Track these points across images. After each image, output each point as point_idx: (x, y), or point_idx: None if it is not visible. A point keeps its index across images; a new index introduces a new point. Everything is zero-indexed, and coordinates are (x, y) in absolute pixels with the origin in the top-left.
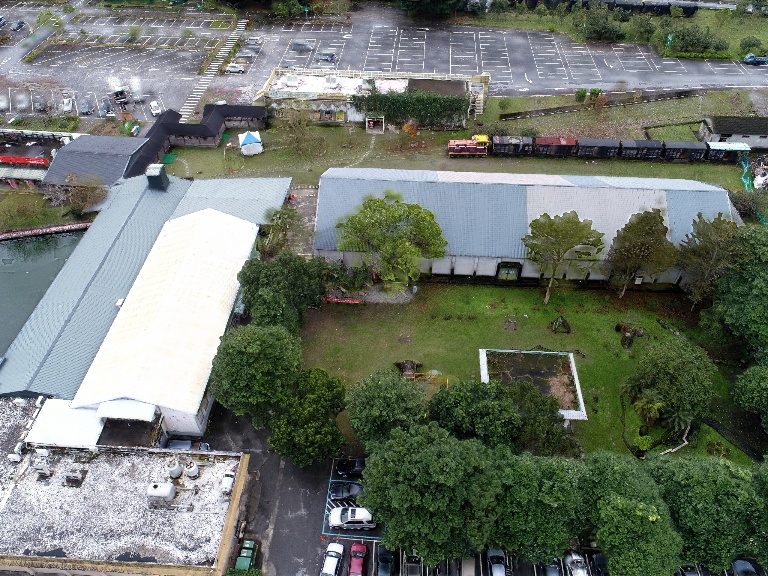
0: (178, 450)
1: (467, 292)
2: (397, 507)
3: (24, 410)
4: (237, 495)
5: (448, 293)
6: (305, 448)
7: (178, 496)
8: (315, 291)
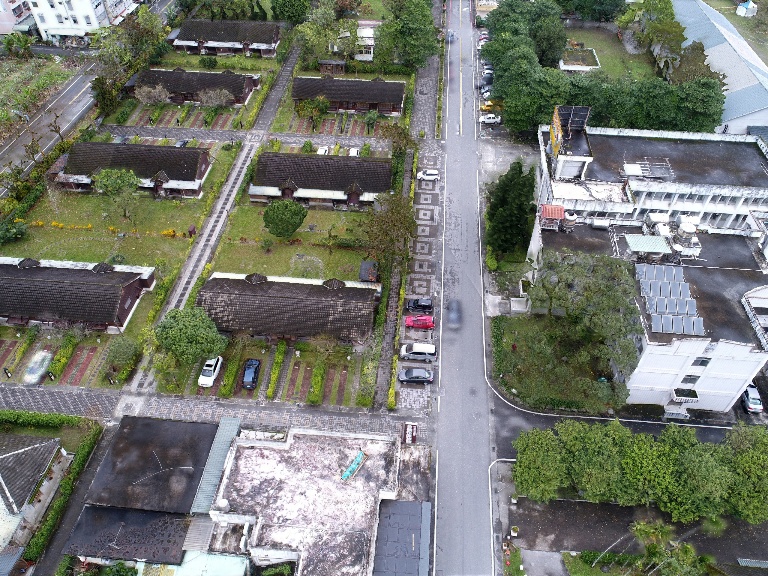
0: None
1: (647, 68)
2: (497, 1)
3: None
4: None
5: (643, 63)
6: None
7: None
8: (605, 5)
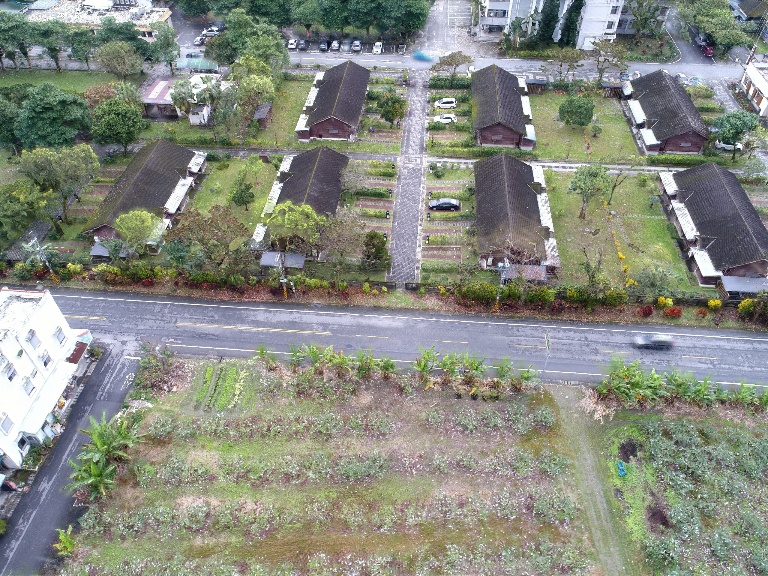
0: (143, 7)
1: None
2: None
3: (81, 3)
4: (165, 18)
5: None
6: (192, 3)
7: (142, 18)
8: None
